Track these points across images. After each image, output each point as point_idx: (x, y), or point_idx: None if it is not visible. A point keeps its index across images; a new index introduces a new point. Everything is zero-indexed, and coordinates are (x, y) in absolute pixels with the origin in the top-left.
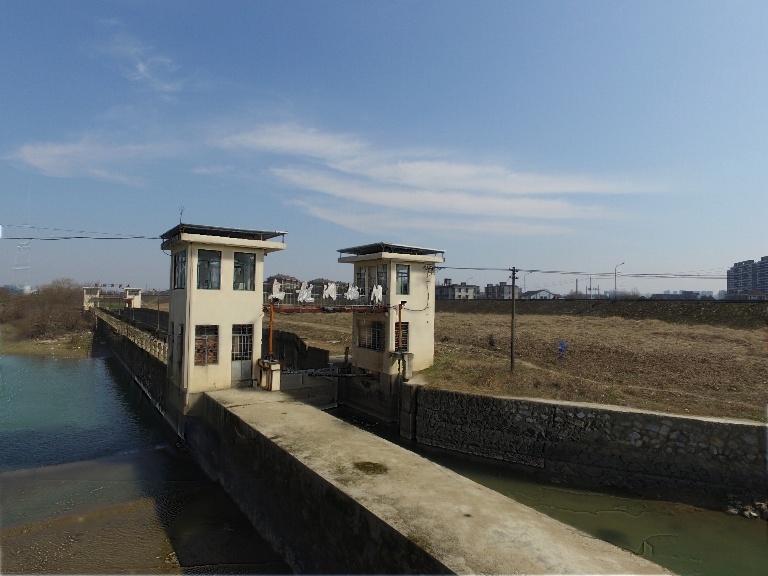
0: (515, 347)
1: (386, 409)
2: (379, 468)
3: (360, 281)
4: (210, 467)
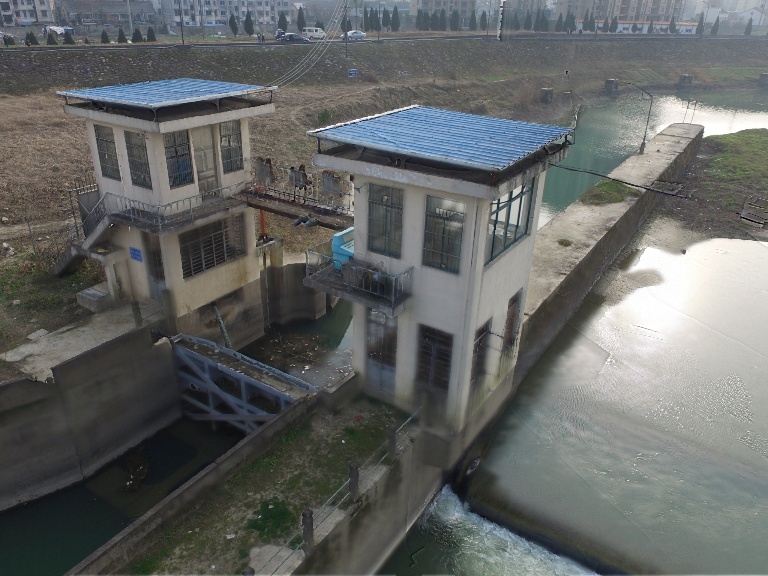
0: (14, 208)
1: (259, 324)
2: (564, 240)
3: (178, 161)
4: (507, 399)
